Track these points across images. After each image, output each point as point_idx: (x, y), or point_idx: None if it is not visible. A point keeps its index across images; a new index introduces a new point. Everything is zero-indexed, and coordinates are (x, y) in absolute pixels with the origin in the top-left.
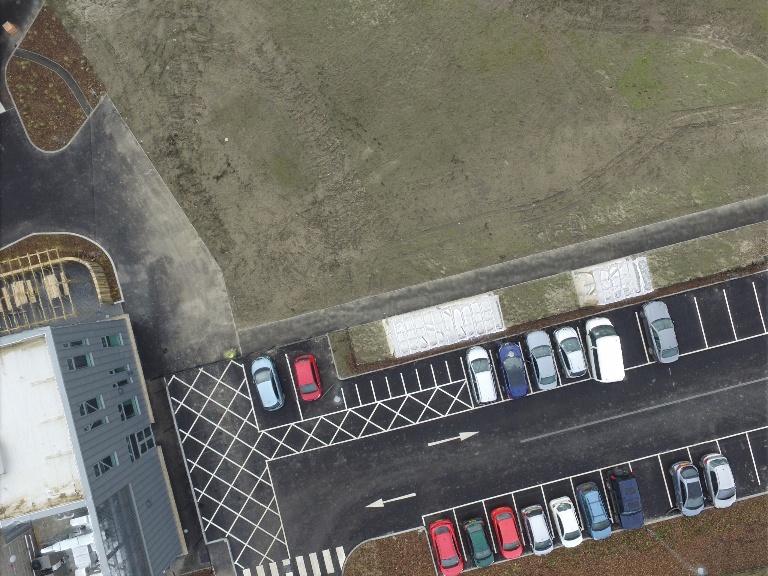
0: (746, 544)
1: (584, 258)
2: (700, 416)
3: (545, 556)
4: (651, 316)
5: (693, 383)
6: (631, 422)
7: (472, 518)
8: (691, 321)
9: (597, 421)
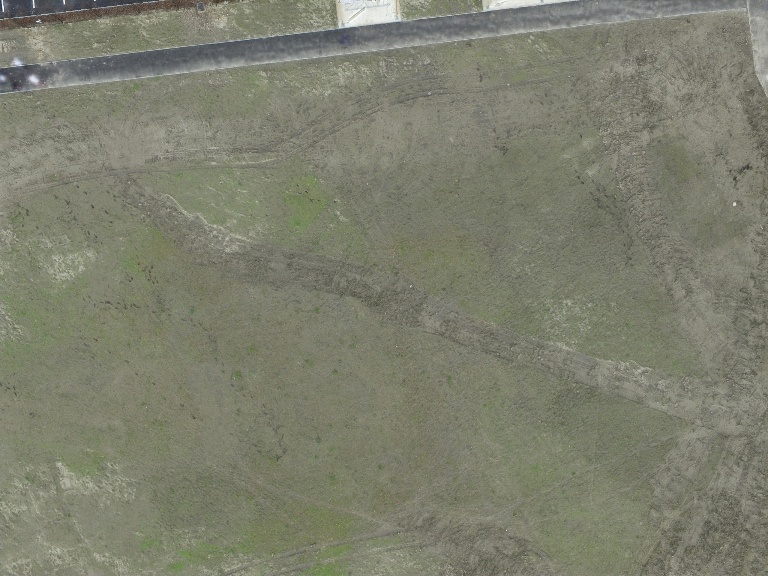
0: None
1: (386, 33)
2: None
3: None
4: None
5: None
6: None
7: None
8: None
9: None
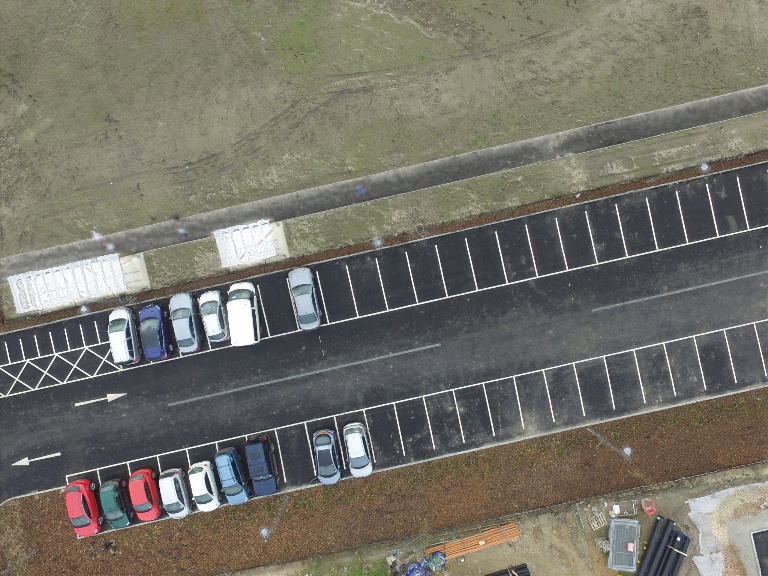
0: (386, 515)
1: (235, 222)
2: (349, 385)
3: (186, 520)
4: (292, 282)
5: (343, 352)
6: (280, 389)
7: (111, 479)
8: (342, 289)
9: (246, 387)
